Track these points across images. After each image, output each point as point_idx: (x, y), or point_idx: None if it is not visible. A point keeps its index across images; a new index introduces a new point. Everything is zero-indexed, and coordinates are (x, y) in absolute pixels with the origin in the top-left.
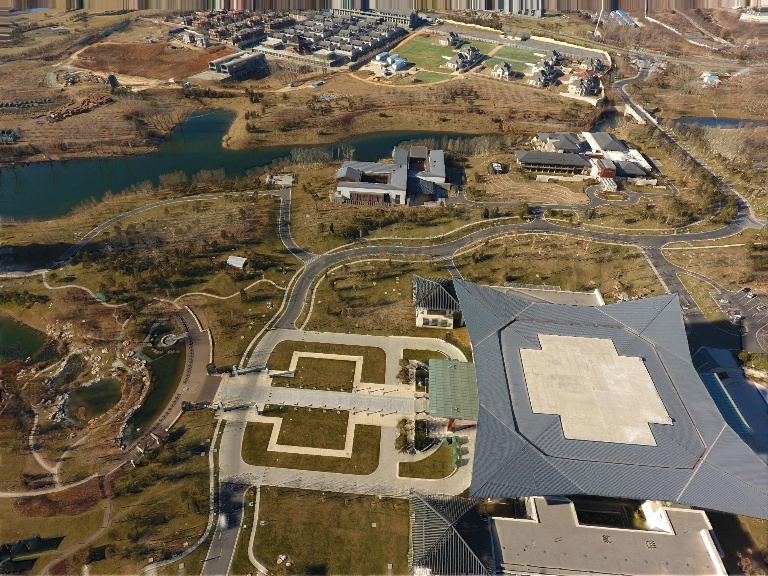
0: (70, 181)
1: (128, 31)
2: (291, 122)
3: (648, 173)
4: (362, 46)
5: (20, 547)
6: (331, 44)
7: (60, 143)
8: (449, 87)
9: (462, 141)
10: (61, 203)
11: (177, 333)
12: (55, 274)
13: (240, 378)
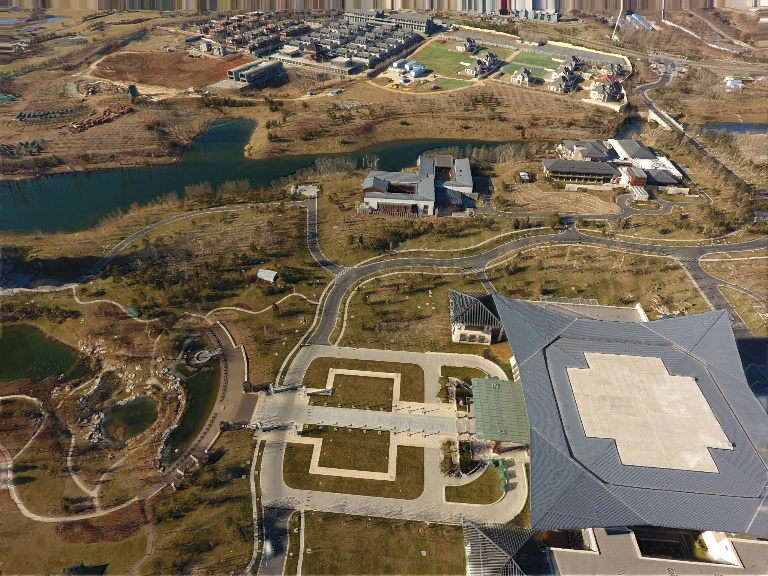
0: (93, 192)
1: (145, 40)
2: (313, 131)
3: (679, 181)
4: (379, 53)
5: (64, 575)
6: (348, 51)
7: (84, 154)
8: (469, 94)
9: (486, 149)
10: (87, 215)
11: (210, 349)
12: (86, 288)
13: (277, 396)
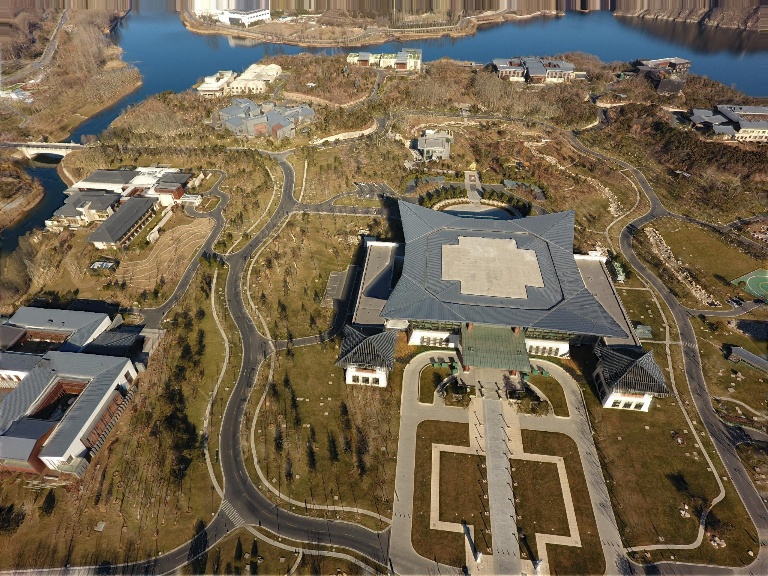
0: None
1: None
2: None
3: None
4: None
5: None
6: None
7: None
8: None
9: None
10: None
11: None
12: None
13: None
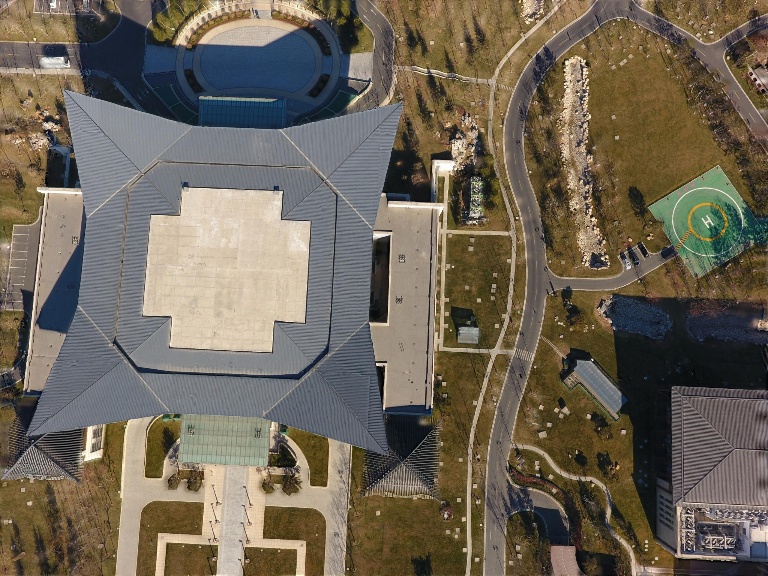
0: None
1: None
2: None
3: None
4: None
5: None
6: None
7: None
8: None
9: None
10: None
11: None
12: None
13: None
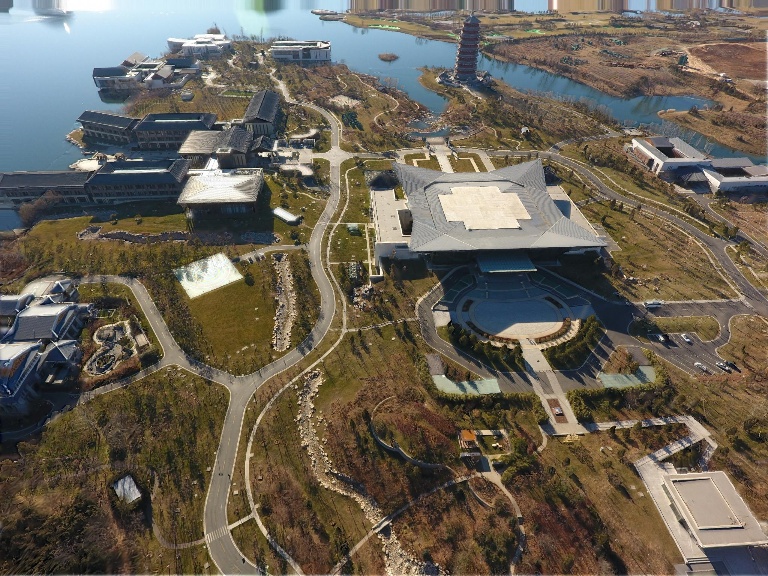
0: None
1: None
2: (729, 121)
3: None
4: None
5: None
6: None
7: (587, 73)
8: None
9: None
10: None
11: (465, 131)
12: None
13: (447, 148)
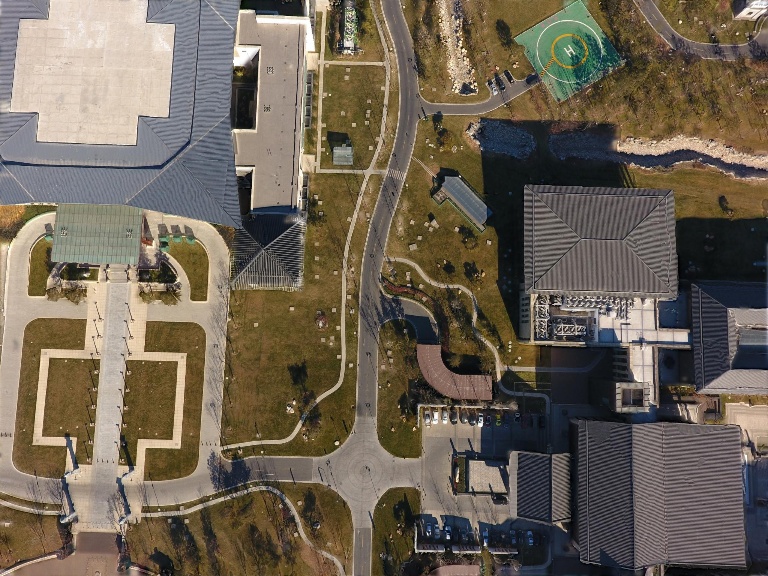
0: None
1: None
2: None
3: None
4: None
5: None
6: None
7: None
8: None
9: None
10: None
11: None
12: None
13: (79, 508)
